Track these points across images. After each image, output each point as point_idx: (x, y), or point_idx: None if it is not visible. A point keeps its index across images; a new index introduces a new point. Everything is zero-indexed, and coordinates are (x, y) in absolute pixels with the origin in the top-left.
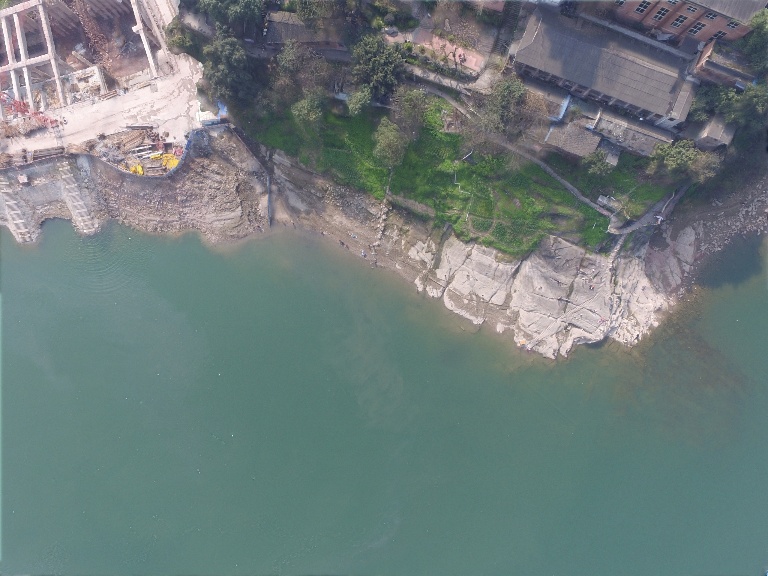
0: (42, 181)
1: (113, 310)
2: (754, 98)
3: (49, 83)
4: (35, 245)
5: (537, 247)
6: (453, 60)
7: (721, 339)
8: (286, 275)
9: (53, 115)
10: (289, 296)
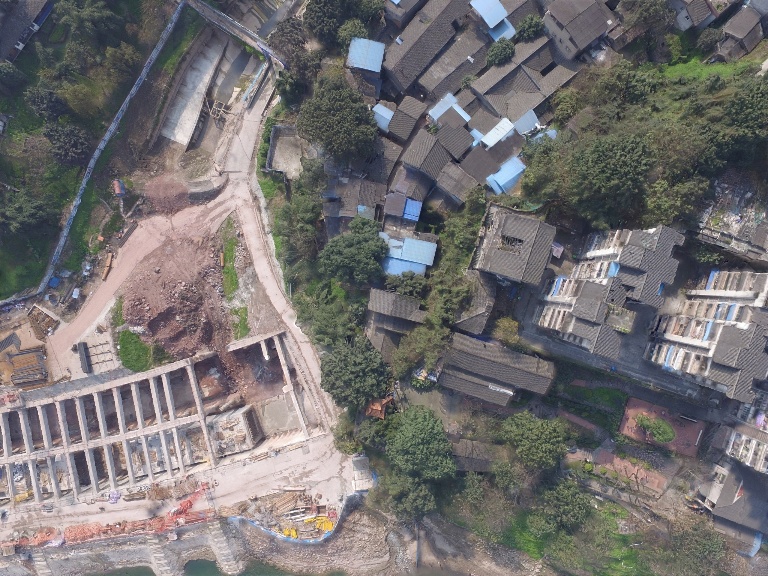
0: (190, 535)
1: None
2: None
3: (193, 430)
4: None
5: None
6: (635, 481)
7: None
8: None
9: (204, 477)
10: None
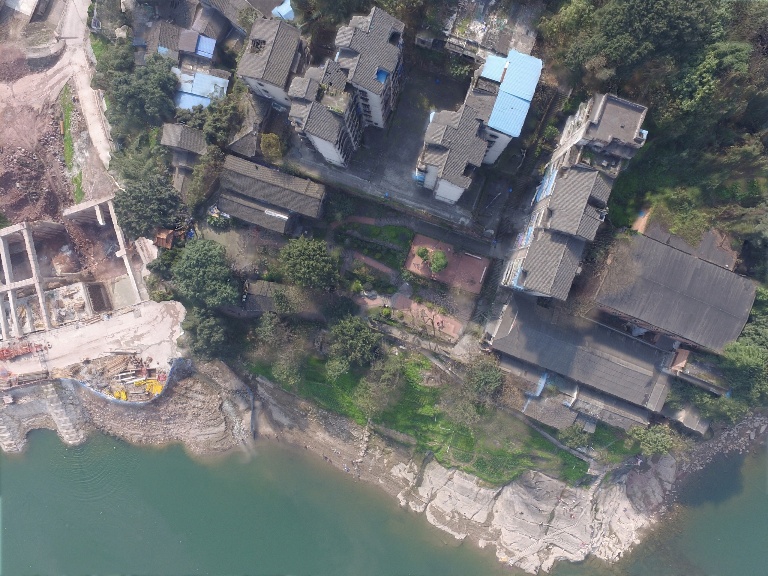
0: (27, 399)
1: (98, 519)
2: (728, 412)
3: (34, 298)
4: (21, 454)
5: (518, 478)
6: (431, 326)
7: (702, 557)
8: (270, 487)
9: (37, 339)
10: (273, 507)
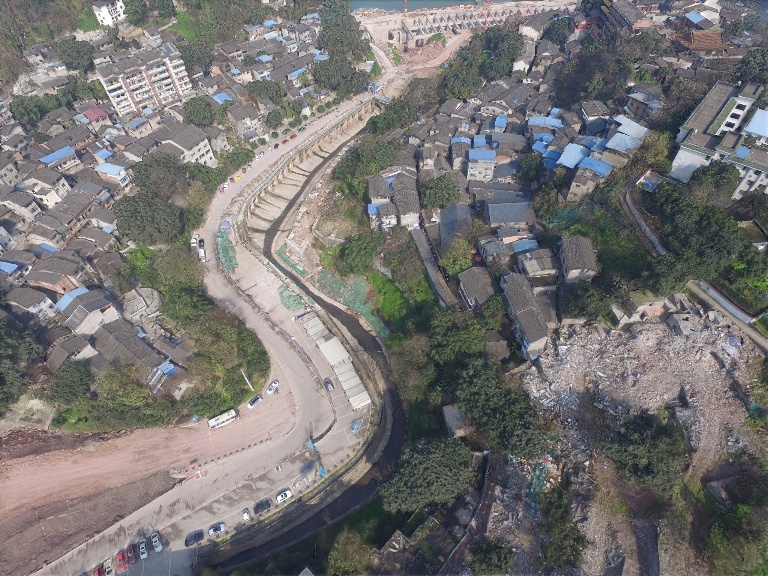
0: None
1: (390, 3)
2: None
3: None
4: None
5: None
6: None
7: None
8: None
9: None
10: None
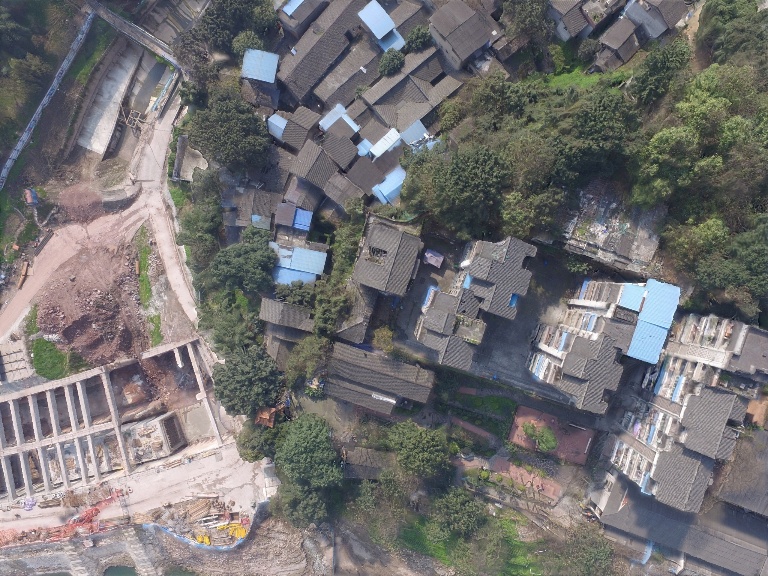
0: (107, 542)
1: None
2: None
3: (111, 437)
4: None
5: None
6: None
7: None
8: None
9: (118, 484)
10: None
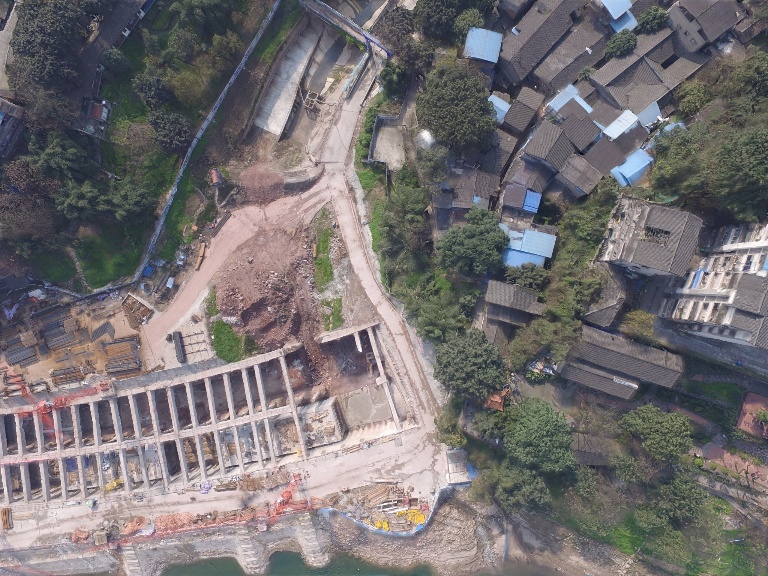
0: (279, 526)
1: None
2: None
3: (281, 422)
4: None
5: None
6: (745, 476)
7: None
8: None
9: (296, 468)
10: None
